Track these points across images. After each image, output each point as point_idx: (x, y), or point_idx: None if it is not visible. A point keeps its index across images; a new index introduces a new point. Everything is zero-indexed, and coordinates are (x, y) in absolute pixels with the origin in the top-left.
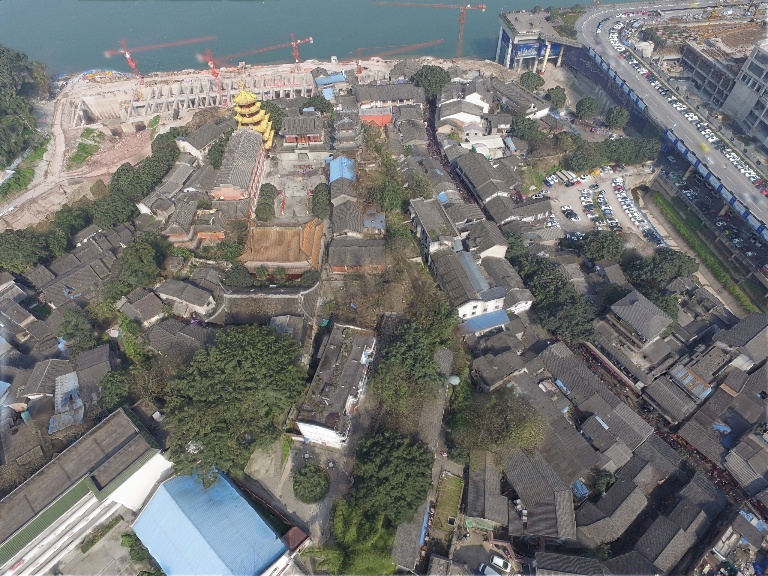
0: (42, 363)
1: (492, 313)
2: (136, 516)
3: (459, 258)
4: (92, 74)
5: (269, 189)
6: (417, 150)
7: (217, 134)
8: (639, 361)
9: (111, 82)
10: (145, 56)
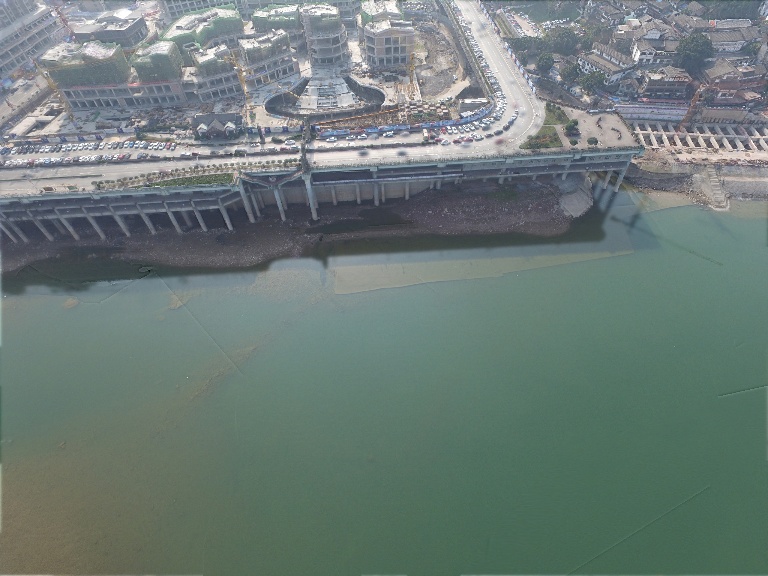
0: None
1: None
2: None
3: None
4: None
5: None
6: None
7: None
8: None
9: None
10: None
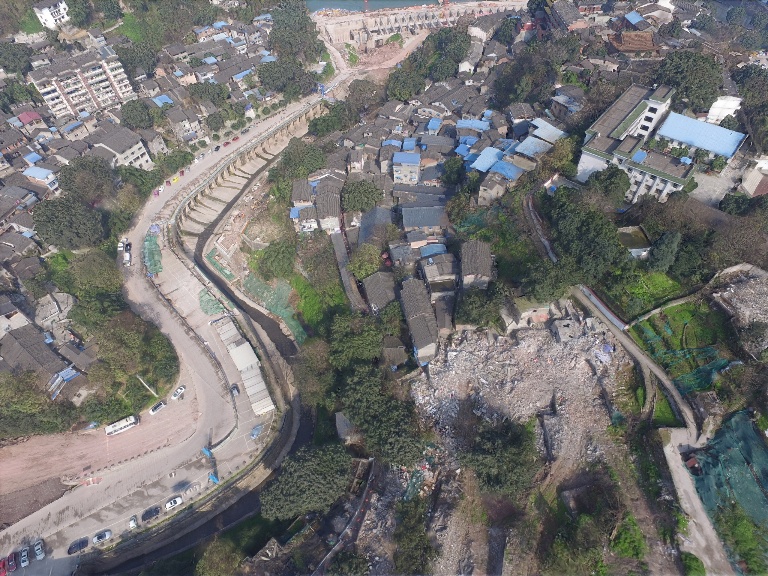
0: (515, 105)
1: None
2: (661, 126)
3: None
4: (322, 11)
5: (593, 30)
6: None
7: (494, 24)
8: None
9: (341, 16)
10: (345, 3)
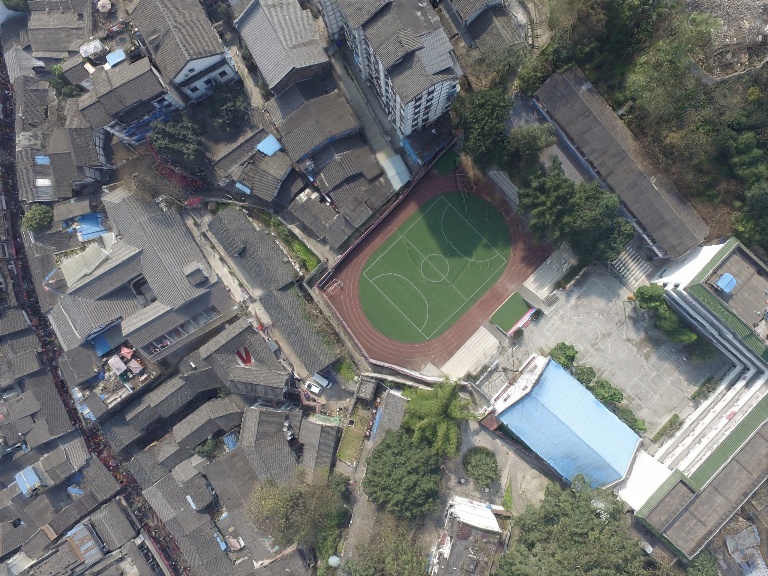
0: None
1: None
2: None
3: None
4: None
5: None
6: None
7: None
8: (130, 569)
9: None
10: None
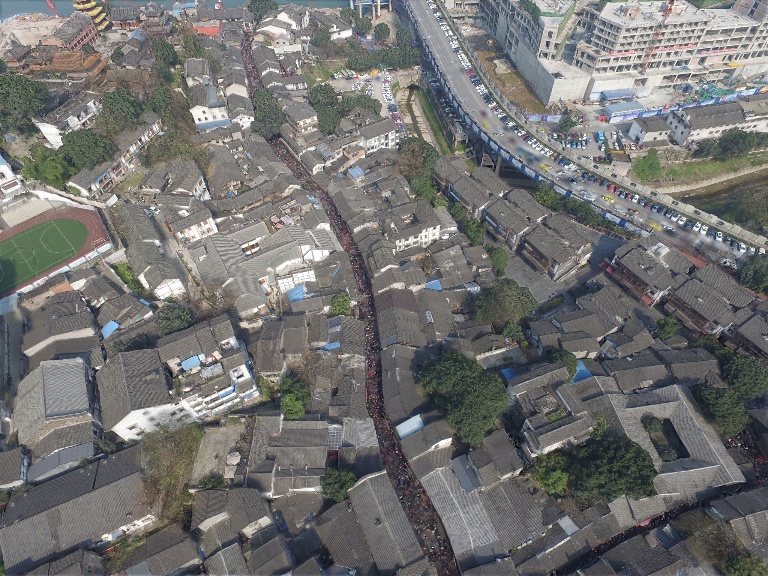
0: None
1: (221, 121)
2: None
3: (206, 89)
4: (24, 16)
5: (86, 46)
6: (231, 49)
7: None
8: (302, 143)
9: (37, 21)
10: None
